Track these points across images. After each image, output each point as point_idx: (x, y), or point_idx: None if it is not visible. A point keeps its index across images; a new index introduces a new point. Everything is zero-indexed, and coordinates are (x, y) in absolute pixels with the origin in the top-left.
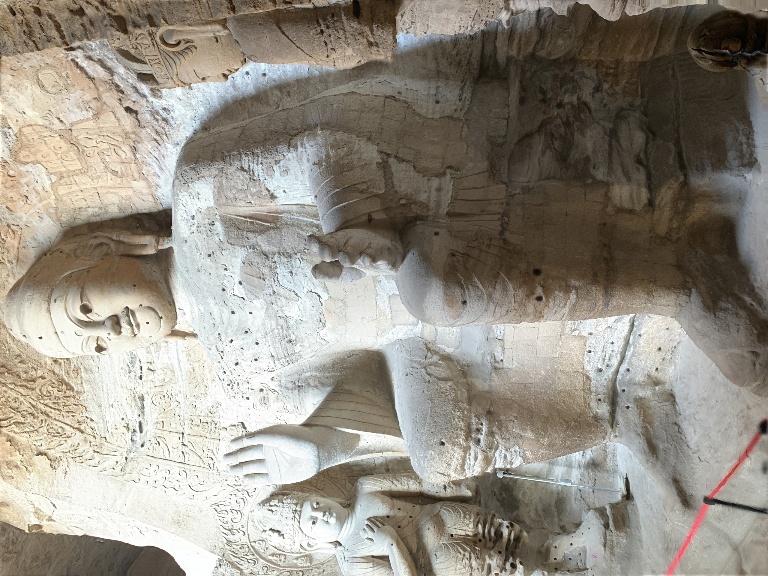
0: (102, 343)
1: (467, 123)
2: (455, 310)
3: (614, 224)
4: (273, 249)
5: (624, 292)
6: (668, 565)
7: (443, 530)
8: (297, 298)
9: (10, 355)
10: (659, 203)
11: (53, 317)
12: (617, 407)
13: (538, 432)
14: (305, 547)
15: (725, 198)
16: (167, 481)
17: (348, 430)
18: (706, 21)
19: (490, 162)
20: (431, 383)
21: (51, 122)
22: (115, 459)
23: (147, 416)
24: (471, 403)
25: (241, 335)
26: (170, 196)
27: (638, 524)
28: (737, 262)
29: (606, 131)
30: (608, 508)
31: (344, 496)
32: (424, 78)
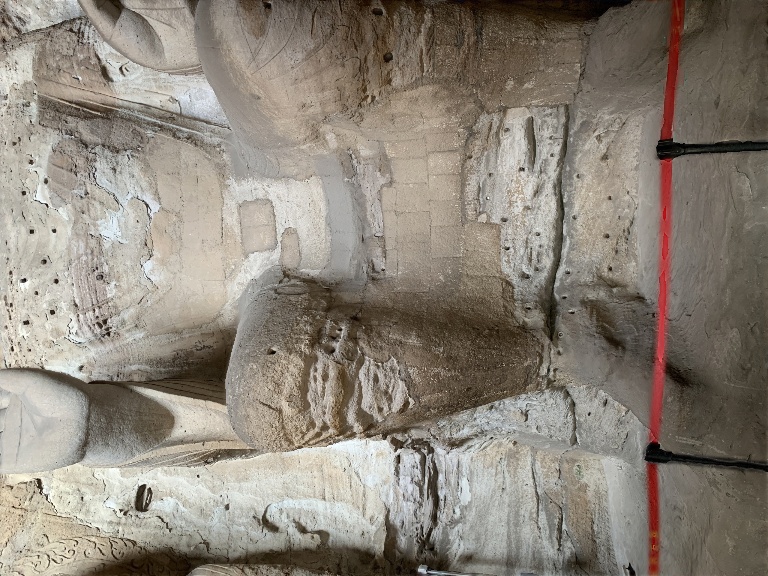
0: None
1: None
2: (254, 16)
3: None
4: (97, 140)
5: (501, 17)
6: None
7: None
8: (117, 206)
9: None
10: None
11: None
12: (556, 316)
13: (429, 338)
14: None
15: None
16: None
17: (151, 392)
18: None
19: None
20: (277, 299)
21: None
22: None
23: None
24: (329, 310)
25: (37, 268)
26: None
27: None
28: None
29: None
30: None
31: None
32: None
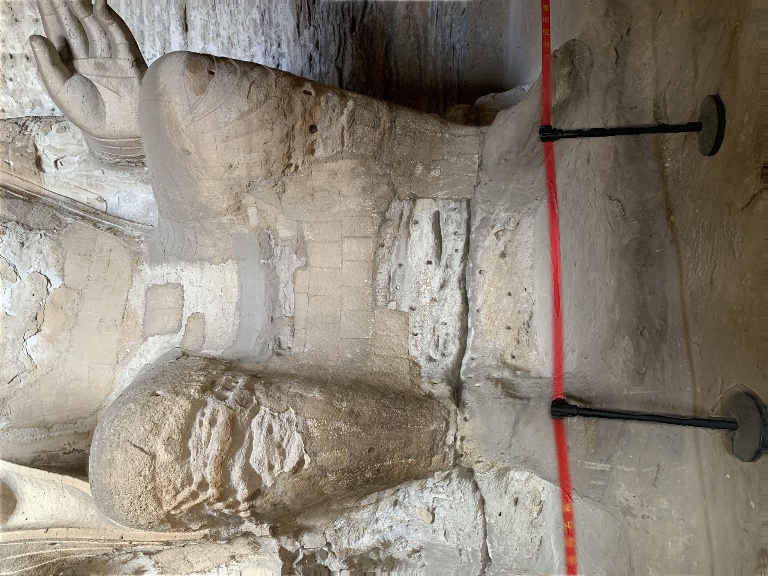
0: None
1: None
2: (198, 78)
3: None
4: (12, 217)
5: (412, 114)
6: None
7: None
8: (15, 277)
9: None
10: None
11: None
12: (463, 390)
13: (331, 394)
14: None
15: None
16: None
17: None
18: None
19: None
20: None
21: None
22: None
23: None
24: None
25: None
26: None
27: None
28: None
29: None
30: None
31: None
32: None
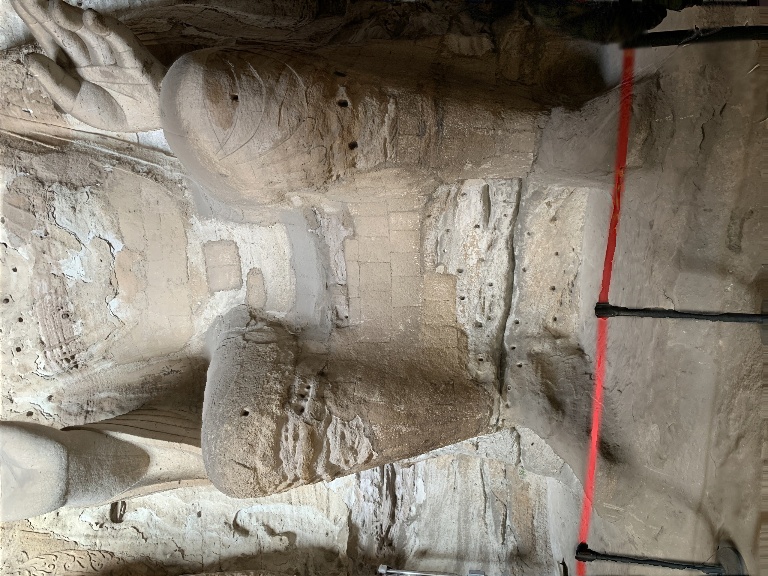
0: None
1: (296, 31)
2: (221, 109)
3: (451, 65)
4: (53, 177)
5: (461, 108)
6: None
7: None
8: (79, 245)
9: None
10: (504, 47)
11: None
12: (506, 368)
13: (391, 396)
14: None
15: (580, 35)
16: None
17: (126, 436)
18: None
19: (311, 38)
20: (246, 348)
21: None
22: None
23: None
24: (297, 364)
25: None
26: None
27: None
28: (606, 88)
29: (446, 18)
30: None
31: None
32: (259, 14)
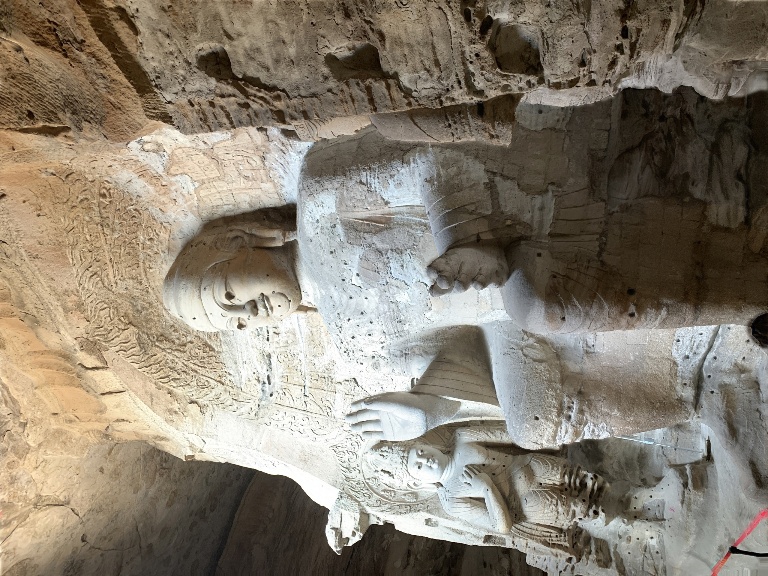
0: (242, 321)
1: (569, 134)
2: (554, 324)
3: (709, 242)
4: (386, 246)
5: (713, 309)
6: (740, 528)
7: (533, 479)
8: (407, 287)
9: (166, 326)
10: (755, 222)
11: (203, 302)
12: (702, 391)
13: (625, 412)
14: (411, 486)
15: None
16: (293, 425)
17: (451, 398)
18: (758, 324)
19: (590, 178)
20: (527, 364)
21: (197, 144)
22: (250, 406)
23: (274, 371)
24: (563, 383)
25: (357, 315)
26: (293, 194)
27: (716, 485)
28: None
29: (708, 145)
30: (688, 469)
31: (444, 443)
32: None
